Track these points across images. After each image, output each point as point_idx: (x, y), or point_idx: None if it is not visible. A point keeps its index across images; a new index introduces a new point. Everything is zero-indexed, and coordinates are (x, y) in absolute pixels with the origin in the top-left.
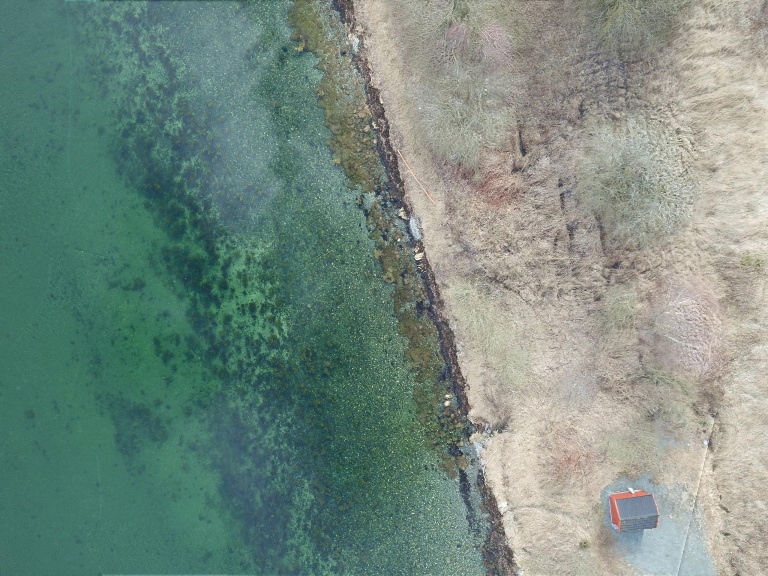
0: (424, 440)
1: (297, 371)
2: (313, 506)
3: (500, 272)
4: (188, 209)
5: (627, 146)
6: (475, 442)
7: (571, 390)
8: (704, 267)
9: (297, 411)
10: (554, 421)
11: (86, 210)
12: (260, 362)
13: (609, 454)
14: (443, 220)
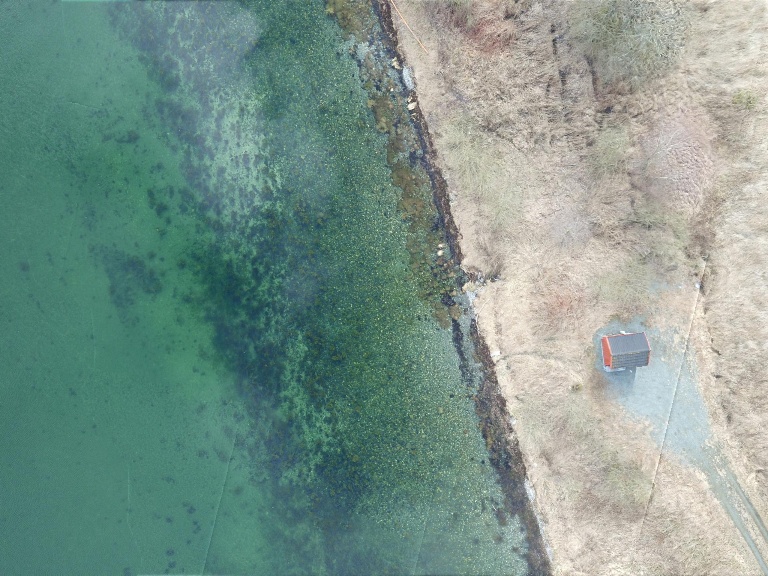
0: (417, 290)
1: (291, 222)
2: (307, 357)
3: (493, 120)
4: (182, 61)
5: None
6: (468, 291)
7: (563, 236)
8: (696, 108)
9: (291, 262)
10: (546, 268)
11: (80, 62)
12: (254, 214)
13: (601, 298)
14: (436, 69)
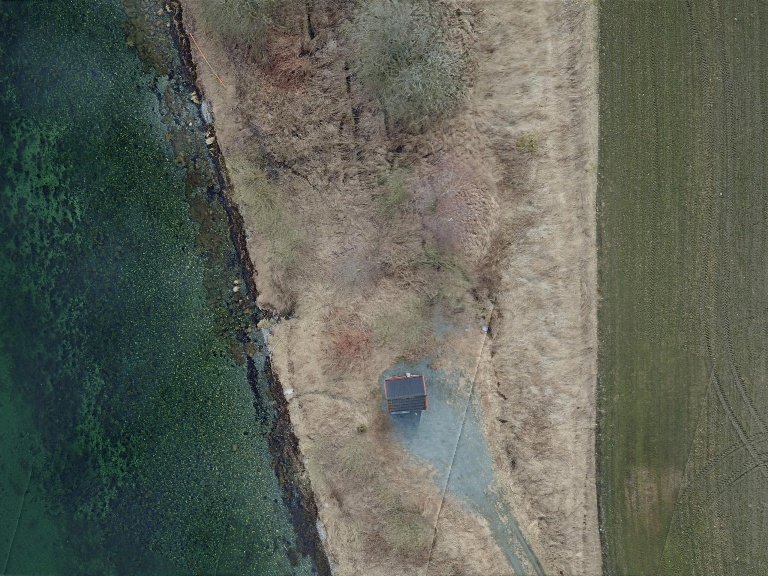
0: (213, 326)
1: (89, 255)
2: (103, 391)
3: (288, 157)
4: None
5: (411, 28)
6: (263, 328)
7: (355, 275)
8: (483, 150)
9: (88, 295)
10: (338, 307)
11: None
12: (53, 246)
13: (389, 339)
14: (233, 104)
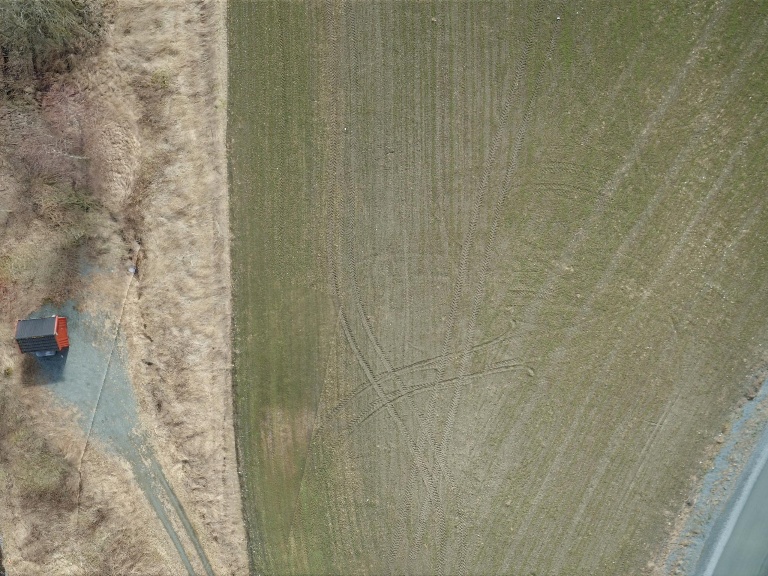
0: None
1: None
2: None
3: None
4: None
5: None
6: None
7: (7, 217)
8: (124, 88)
9: None
10: None
11: None
12: None
13: (36, 281)
14: None
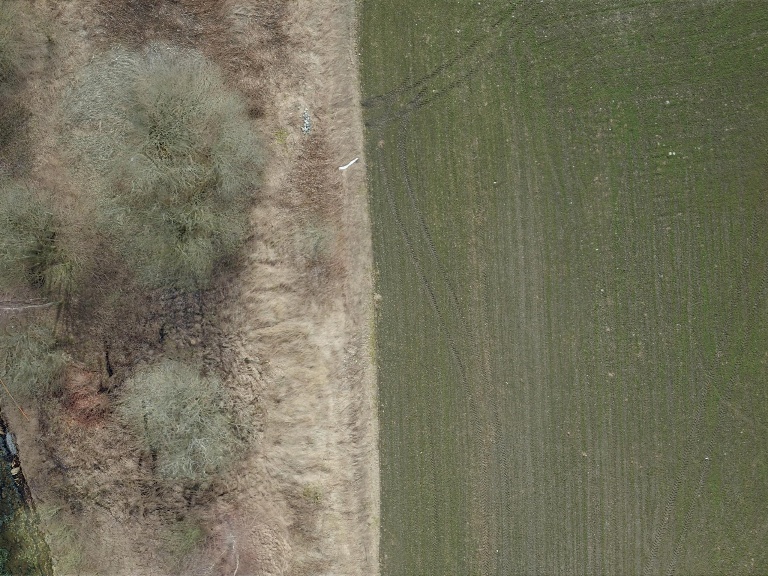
0: None
1: None
2: None
3: (91, 489)
4: None
5: (203, 371)
6: None
7: None
8: (274, 494)
9: None
10: None
11: None
12: None
13: None
14: (37, 436)
